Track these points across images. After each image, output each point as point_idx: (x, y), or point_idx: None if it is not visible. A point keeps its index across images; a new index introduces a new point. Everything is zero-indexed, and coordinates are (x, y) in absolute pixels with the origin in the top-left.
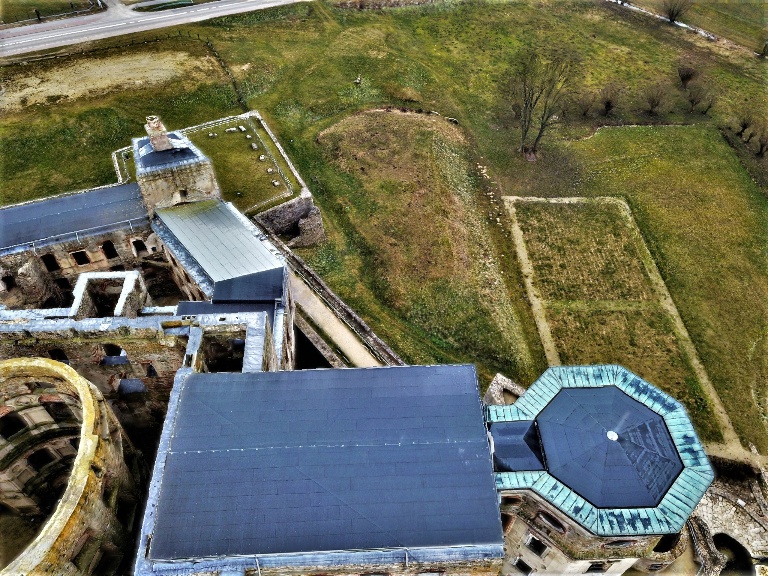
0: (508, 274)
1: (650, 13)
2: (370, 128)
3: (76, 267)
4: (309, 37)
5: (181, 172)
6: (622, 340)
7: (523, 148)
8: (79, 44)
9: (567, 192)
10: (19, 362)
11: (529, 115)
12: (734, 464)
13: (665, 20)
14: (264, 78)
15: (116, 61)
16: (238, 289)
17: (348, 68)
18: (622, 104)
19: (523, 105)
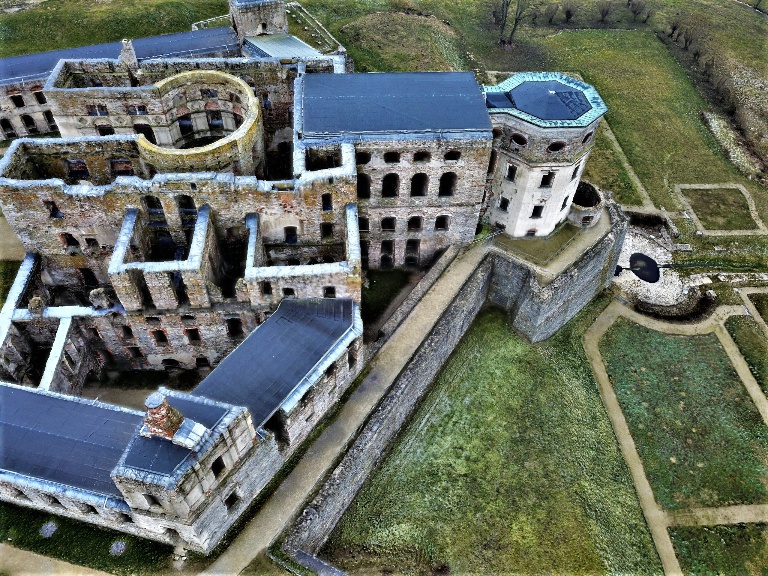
0: None
1: None
2: (382, 22)
3: None
4: None
5: (265, 8)
6: None
7: (501, 40)
8: None
9: (535, 69)
10: (200, 71)
11: (506, 11)
12: (649, 216)
13: None
14: None
15: None
16: None
17: None
18: (580, 16)
19: (501, 2)
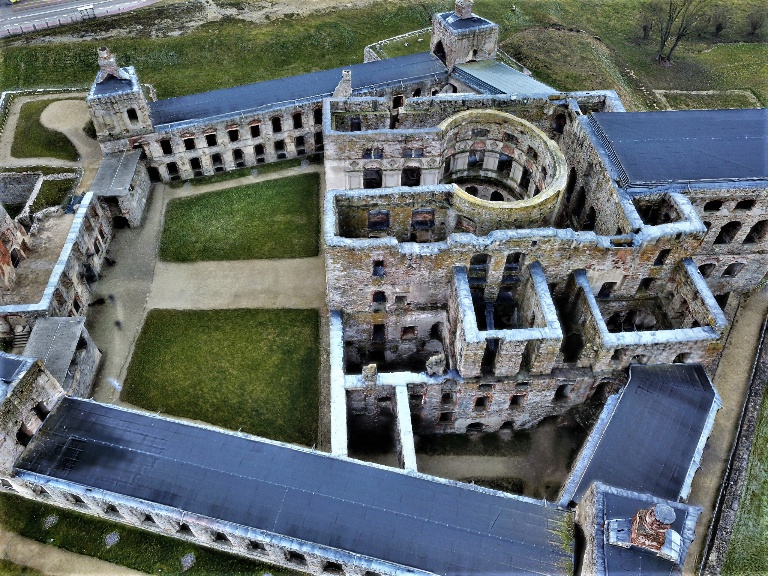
0: None
1: None
2: (540, 39)
3: (392, 110)
4: None
5: (479, 34)
6: None
7: (660, 57)
8: None
9: (703, 87)
10: (477, 111)
11: (670, 27)
12: None
13: None
14: (442, 4)
15: None
16: None
17: None
18: (727, 29)
19: (667, 18)
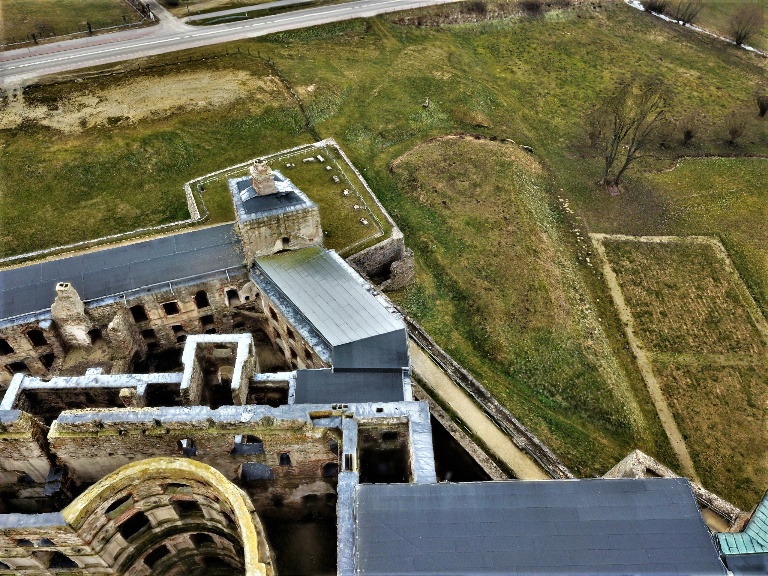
0: (606, 322)
1: (714, 35)
2: (447, 157)
3: (165, 318)
4: (370, 55)
5: (287, 219)
6: (739, 400)
7: (605, 181)
8: (134, 60)
9: (657, 230)
10: (158, 464)
11: (616, 147)
12: None
13: (731, 43)
14: (330, 100)
15: (175, 79)
16: (360, 355)
17: (414, 90)
18: (699, 133)
19: (611, 137)
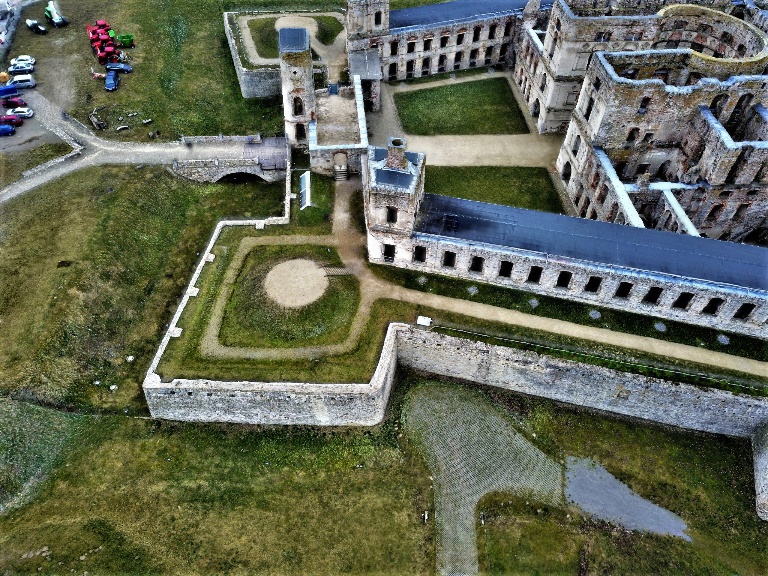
0: None
1: None
2: None
3: None
4: None
5: None
6: None
7: None
8: None
9: None
10: (682, 5)
11: None
12: None
13: None
14: None
15: None
16: None
17: None
18: None
19: None
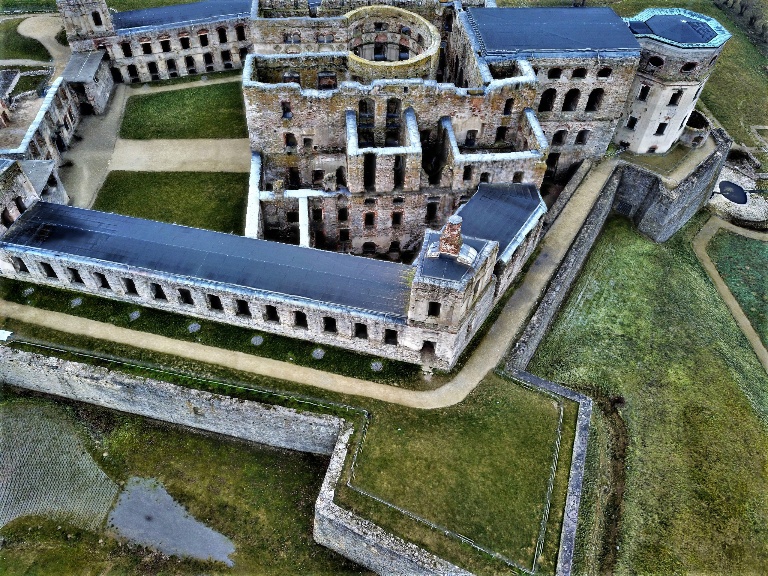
0: None
1: None
2: None
3: None
4: None
5: None
6: None
7: (574, 5)
8: None
9: None
10: (377, 6)
11: None
12: (731, 151)
13: None
14: None
15: None
16: None
17: None
18: None
19: None
